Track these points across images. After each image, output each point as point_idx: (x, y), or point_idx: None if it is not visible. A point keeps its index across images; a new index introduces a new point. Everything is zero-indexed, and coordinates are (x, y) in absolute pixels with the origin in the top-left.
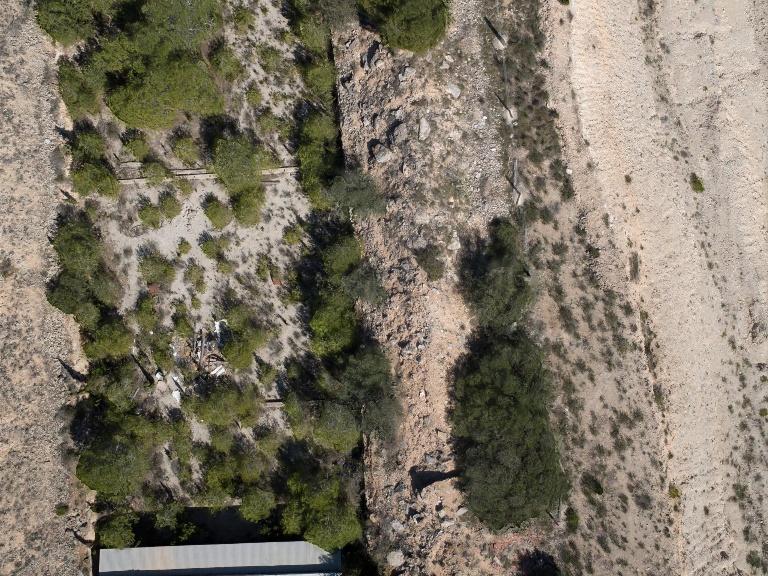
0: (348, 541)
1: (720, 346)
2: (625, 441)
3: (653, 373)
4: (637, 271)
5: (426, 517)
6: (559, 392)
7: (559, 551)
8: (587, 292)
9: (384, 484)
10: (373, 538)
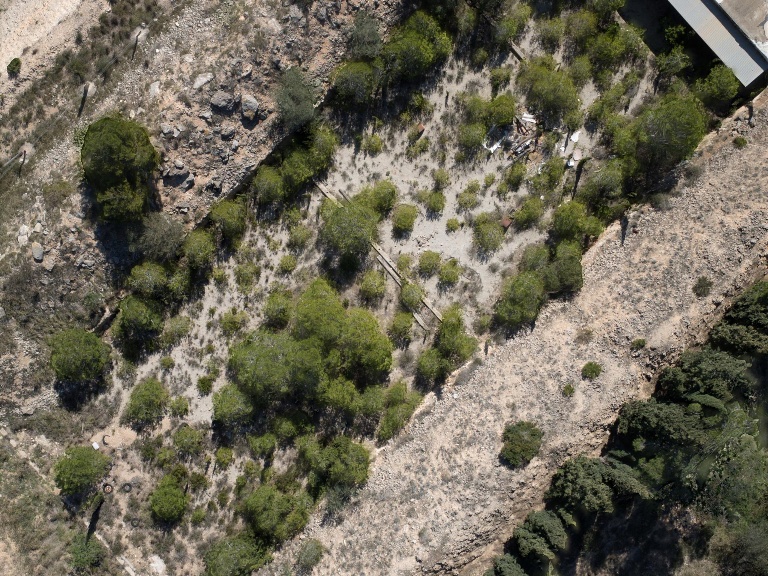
0: None
1: None
2: None
3: None
4: None
5: None
6: None
7: None
8: None
9: None
10: None
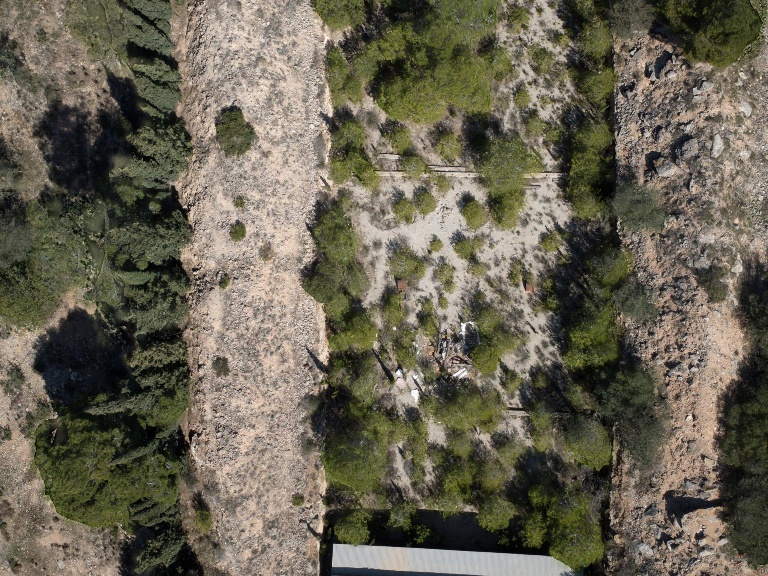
0: (594, 560)
1: None
2: None
3: None
4: None
5: (682, 544)
6: None
7: None
8: None
9: (634, 505)
10: (616, 559)
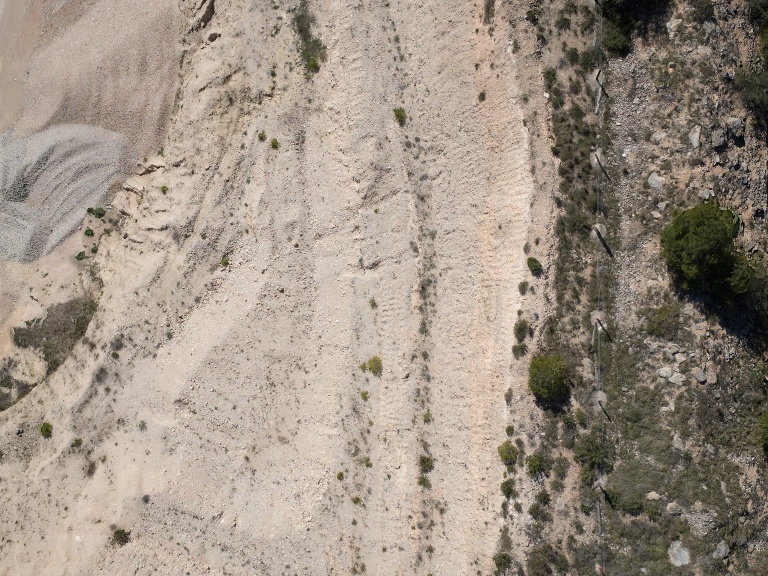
0: None
1: None
2: None
3: None
4: (486, 7)
5: None
6: None
7: None
8: None
9: None
10: None
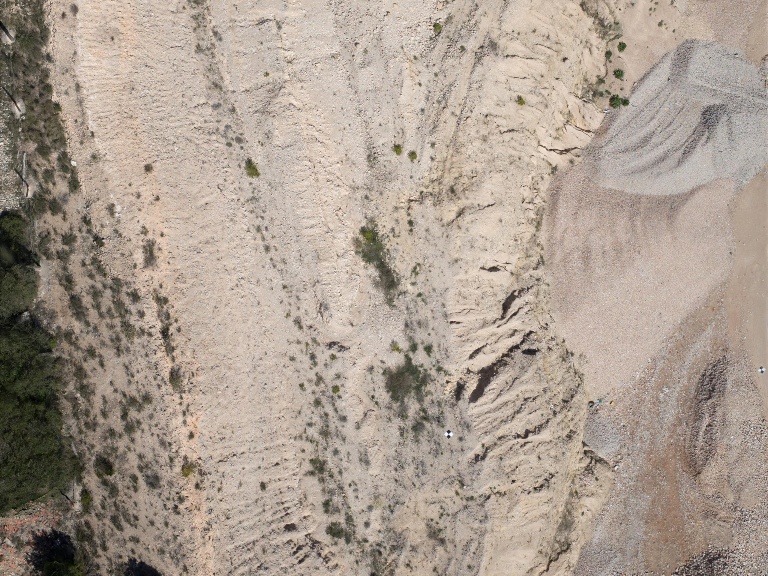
0: None
1: (285, 327)
2: (135, 424)
3: (171, 357)
4: (154, 258)
5: None
6: (71, 378)
7: (75, 531)
8: (96, 280)
9: None
10: None
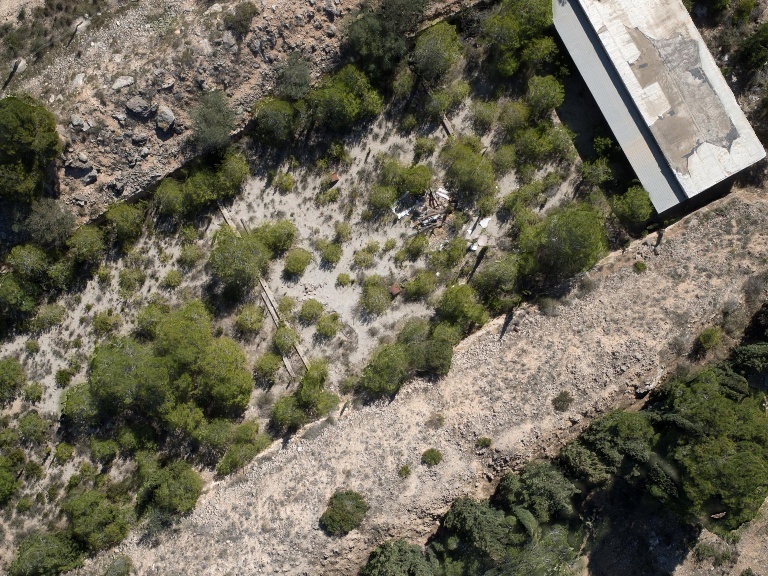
0: None
1: None
2: None
3: None
4: None
5: None
6: None
7: None
8: None
9: None
10: None
